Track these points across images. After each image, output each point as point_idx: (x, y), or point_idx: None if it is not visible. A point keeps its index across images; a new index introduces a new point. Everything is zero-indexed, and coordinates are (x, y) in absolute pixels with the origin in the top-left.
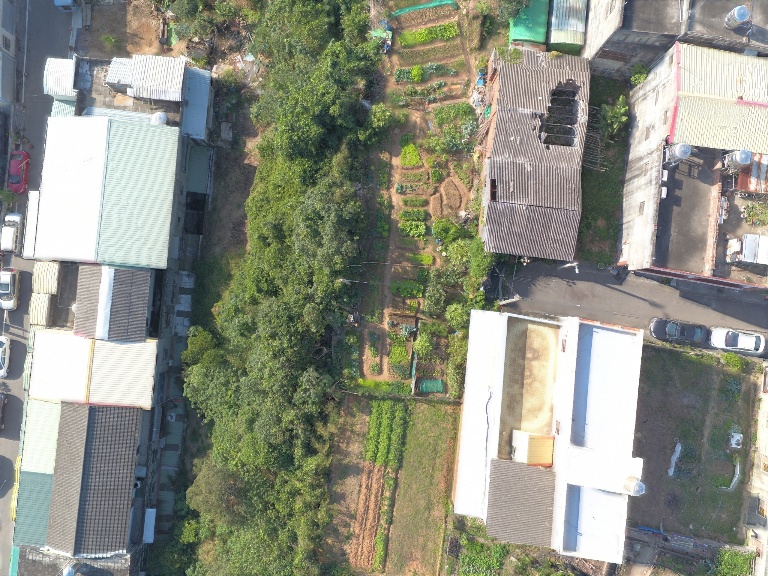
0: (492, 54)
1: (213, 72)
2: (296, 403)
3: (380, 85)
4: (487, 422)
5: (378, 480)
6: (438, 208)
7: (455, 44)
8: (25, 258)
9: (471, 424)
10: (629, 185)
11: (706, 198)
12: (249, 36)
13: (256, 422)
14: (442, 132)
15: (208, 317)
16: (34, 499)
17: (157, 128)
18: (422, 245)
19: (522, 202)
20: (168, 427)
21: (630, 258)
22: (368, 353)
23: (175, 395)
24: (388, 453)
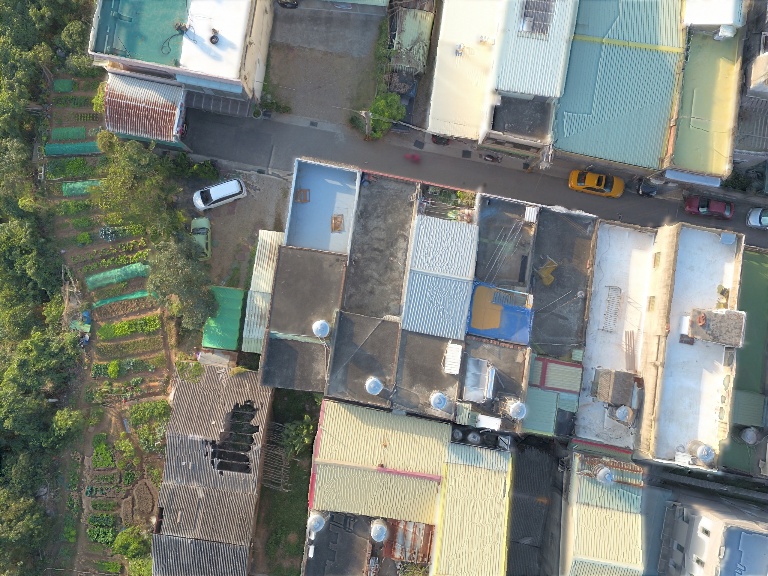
0: None
1: None
2: None
3: (77, 380)
4: None
5: None
6: (129, 512)
7: (155, 339)
8: None
9: None
10: None
11: (361, 552)
12: None
13: None
14: (136, 433)
15: None
16: None
17: None
18: (110, 552)
19: (187, 535)
20: None
21: None
22: None
23: None
24: None
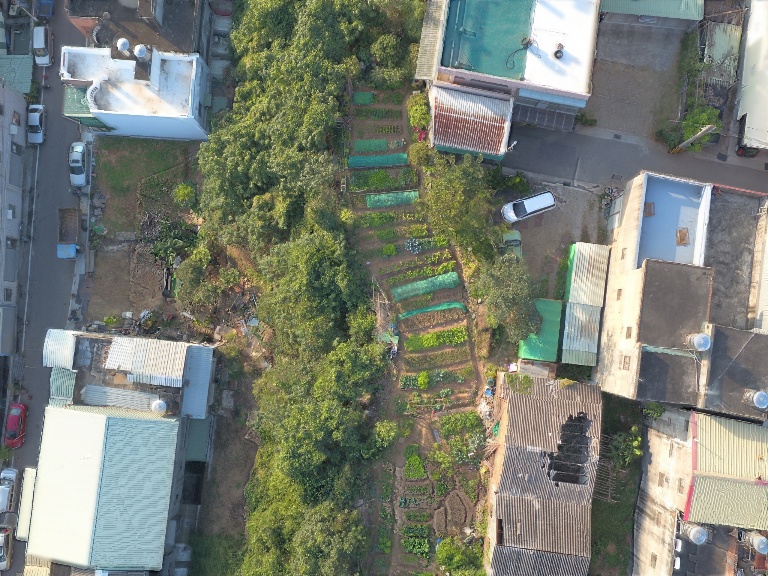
0: (501, 376)
1: (216, 333)
2: None
3: (385, 391)
4: None
5: None
6: (442, 523)
7: (463, 350)
8: (18, 539)
9: None
10: (640, 517)
11: (721, 564)
12: (253, 300)
13: None
14: (448, 444)
15: None
16: None
17: (156, 424)
18: (425, 563)
19: (529, 546)
20: None
21: None
22: None
23: None
24: None
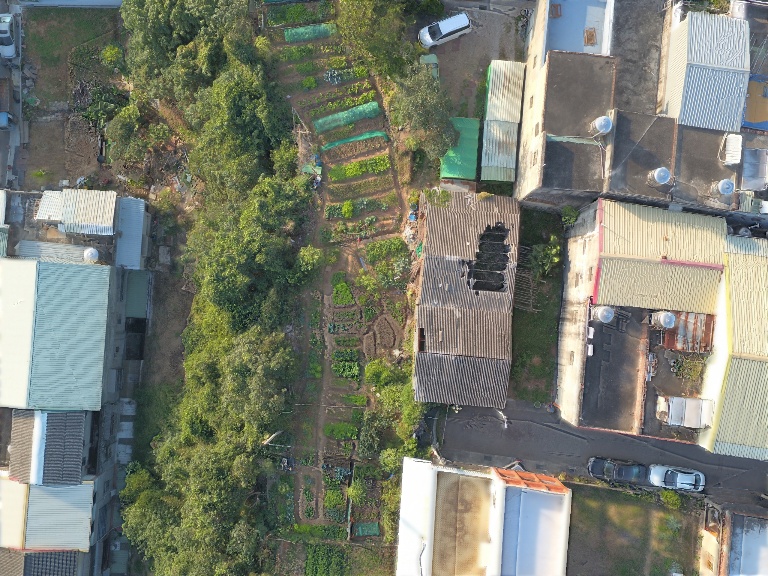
0: None
1: (151, 193)
2: (230, 553)
3: (311, 222)
4: (421, 574)
5: None
6: (372, 347)
7: (386, 178)
8: None
9: (405, 575)
10: (563, 325)
11: (635, 352)
12: (185, 157)
13: (190, 573)
14: (374, 269)
15: (149, 447)
16: None
17: (87, 268)
18: (356, 386)
19: (451, 352)
20: (113, 556)
21: (562, 406)
22: (303, 497)
23: (119, 524)
24: None
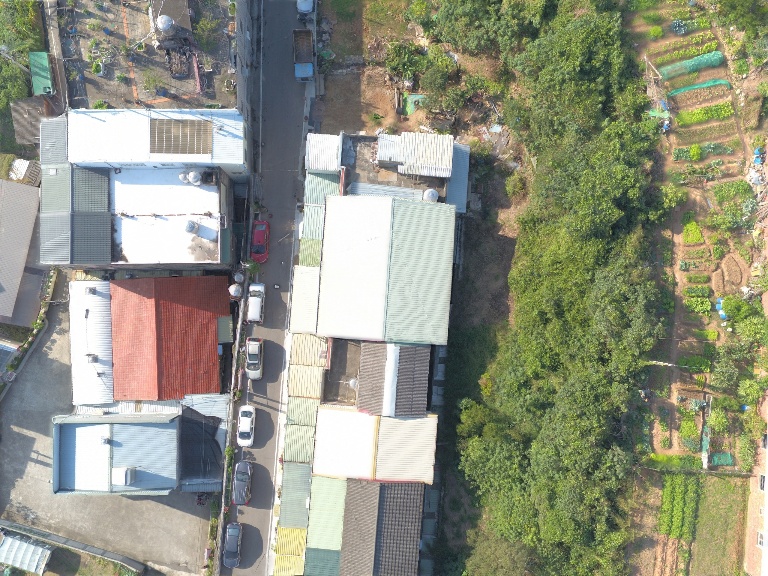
0: None
1: None
2: (596, 479)
3: (659, 164)
4: None
5: (673, 553)
6: (720, 284)
7: (730, 123)
8: (292, 332)
9: None
10: None
11: None
12: (494, 108)
13: (558, 499)
14: (722, 210)
15: (468, 387)
16: (320, 575)
17: (436, 206)
18: (707, 321)
19: None
20: None
21: None
22: (658, 427)
23: None
24: (682, 526)
